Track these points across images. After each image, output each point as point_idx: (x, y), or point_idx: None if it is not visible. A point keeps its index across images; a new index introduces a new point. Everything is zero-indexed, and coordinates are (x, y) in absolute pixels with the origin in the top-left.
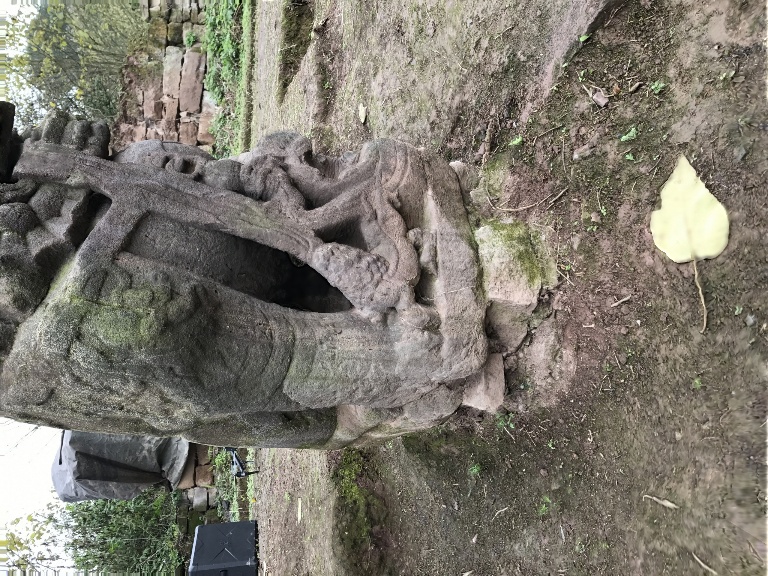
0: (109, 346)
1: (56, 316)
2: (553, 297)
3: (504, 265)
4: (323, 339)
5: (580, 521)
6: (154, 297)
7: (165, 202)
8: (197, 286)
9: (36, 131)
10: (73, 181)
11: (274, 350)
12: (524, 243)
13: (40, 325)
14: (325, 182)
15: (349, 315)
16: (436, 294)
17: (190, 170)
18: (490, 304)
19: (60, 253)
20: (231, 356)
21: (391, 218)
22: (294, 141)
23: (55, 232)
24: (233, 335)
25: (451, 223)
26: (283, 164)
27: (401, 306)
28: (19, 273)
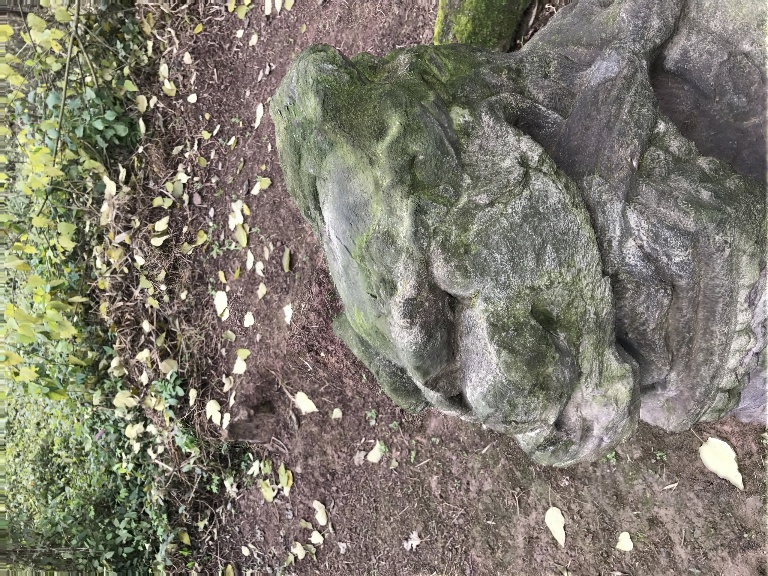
0: None
1: None
2: None
3: None
4: None
5: None
6: None
7: None
8: None
9: None
10: None
11: None
12: None
13: None
14: None
15: None
16: None
17: None
18: None
19: None
20: None
21: None
22: None
23: None
24: None
25: None
26: None
27: None
28: None
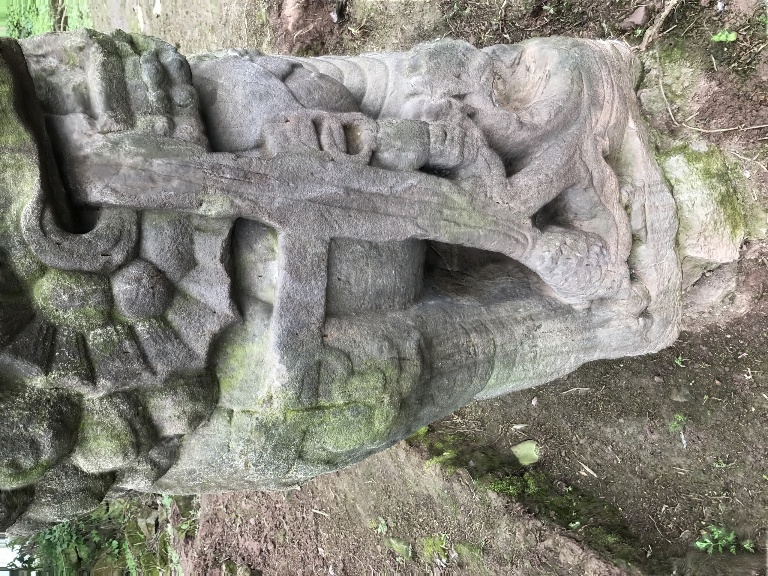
0: (337, 452)
1: (269, 441)
2: (748, 246)
3: (710, 217)
4: (524, 339)
5: (715, 438)
6: (386, 379)
7: (351, 218)
8: (420, 339)
9: (77, 91)
10: (213, 211)
11: (478, 368)
12: (725, 182)
13: (240, 451)
14: (524, 132)
15: (545, 301)
16: (640, 263)
17: (349, 138)
18: (683, 259)
19: (223, 331)
20: (441, 393)
21: (608, 180)
22: (471, 62)
23: (209, 302)
24: (443, 370)
25: (653, 165)
26: (471, 111)
27: (621, 296)
28: (184, 384)
